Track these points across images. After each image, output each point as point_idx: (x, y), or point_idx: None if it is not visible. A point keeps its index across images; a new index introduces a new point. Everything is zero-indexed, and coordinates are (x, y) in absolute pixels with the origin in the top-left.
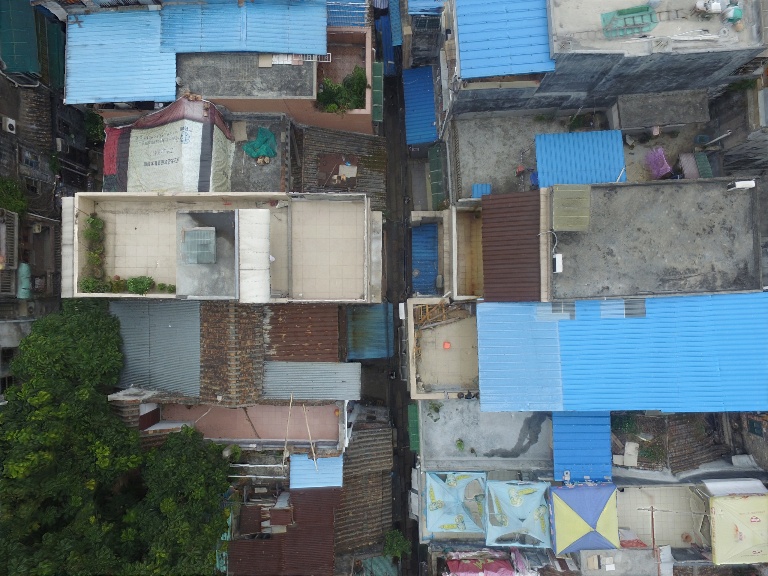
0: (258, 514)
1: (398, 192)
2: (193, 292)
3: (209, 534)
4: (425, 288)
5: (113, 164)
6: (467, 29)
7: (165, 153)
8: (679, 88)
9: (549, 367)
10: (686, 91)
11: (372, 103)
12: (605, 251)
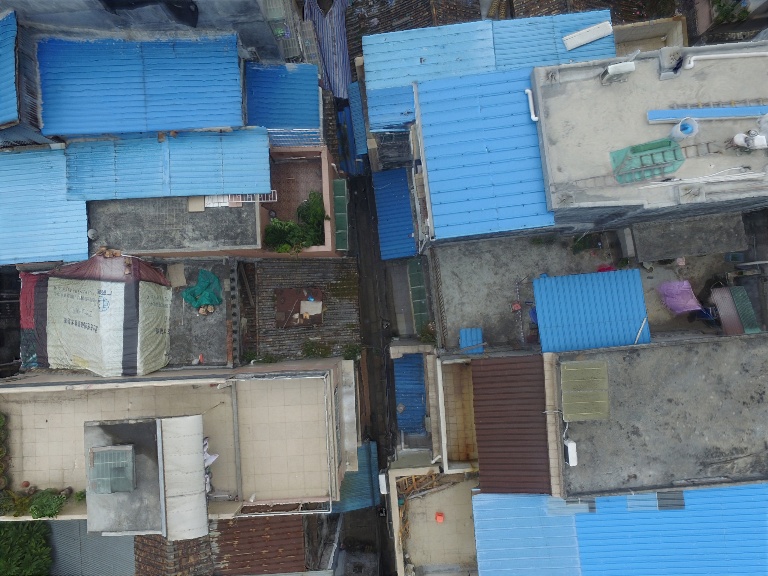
0: None
1: (377, 299)
2: (109, 527)
3: None
4: (412, 426)
5: (30, 317)
6: (439, 175)
7: (84, 314)
8: (708, 213)
9: (566, 573)
10: (716, 214)
11: (334, 229)
12: (629, 430)
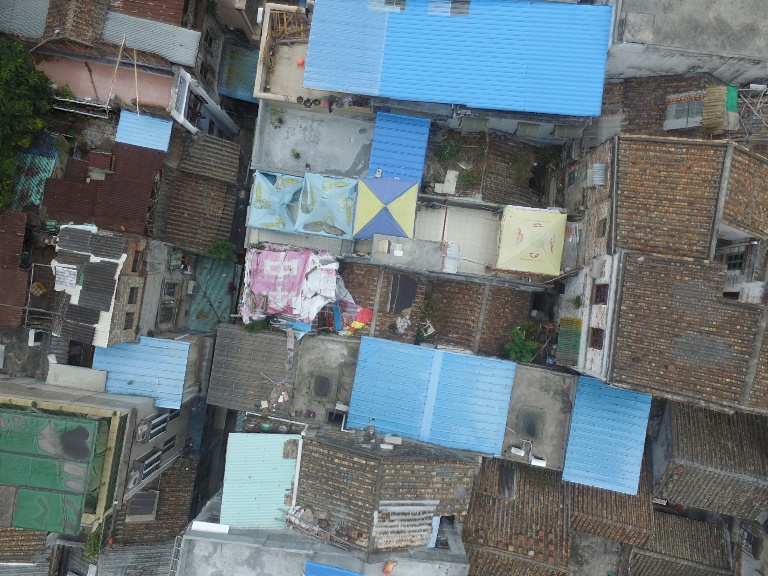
0: (85, 170)
1: None
2: None
3: (3, 103)
4: None
5: None
6: None
7: None
8: None
9: (373, 55)
10: None
11: None
12: None
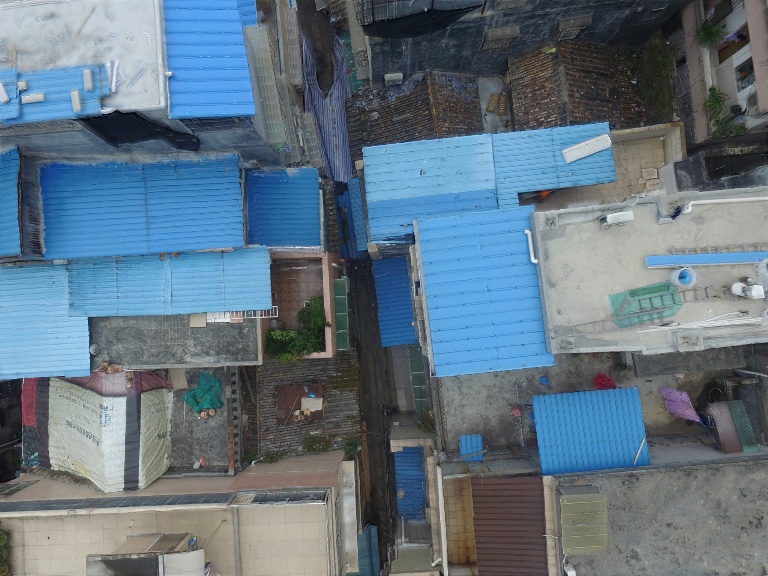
0: None
1: None
2: None
3: None
4: (413, 512)
5: (32, 415)
6: (440, 313)
7: (86, 423)
8: None
9: None
10: None
11: (335, 329)
12: (628, 554)
